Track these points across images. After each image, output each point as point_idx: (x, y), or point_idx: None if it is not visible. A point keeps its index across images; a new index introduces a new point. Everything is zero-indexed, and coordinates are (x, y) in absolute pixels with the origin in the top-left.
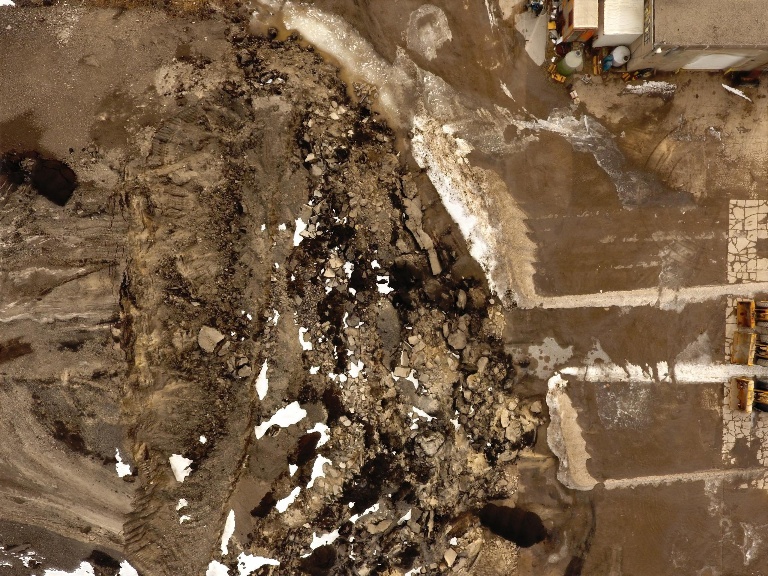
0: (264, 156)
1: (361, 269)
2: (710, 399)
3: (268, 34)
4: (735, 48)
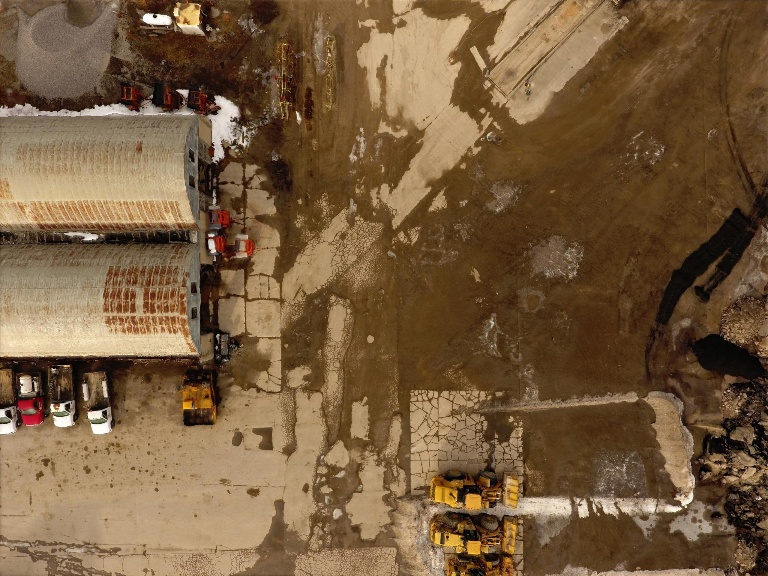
0: None
1: None
2: (536, 481)
3: None
4: None
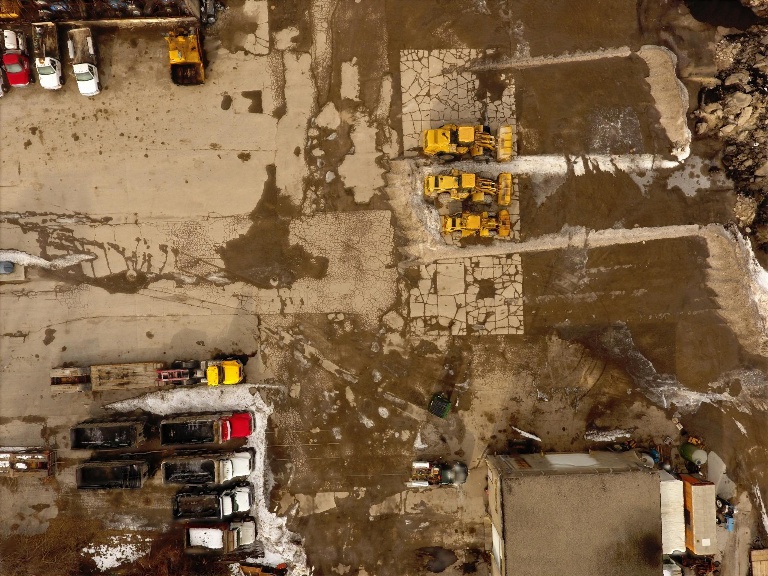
0: None
1: None
2: (530, 139)
3: None
4: (582, 471)
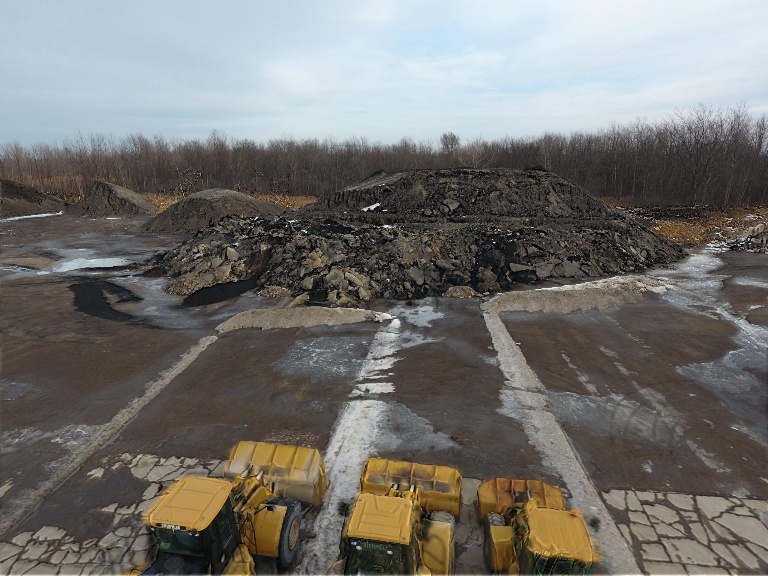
0: None
1: None
2: (288, 443)
3: None
4: None
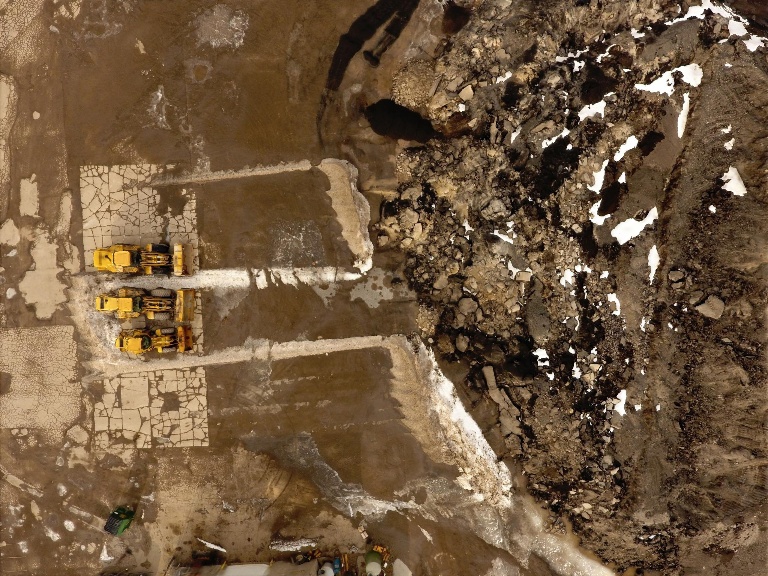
0: (659, 472)
1: (566, 372)
2: (212, 253)
3: (643, 572)
4: None
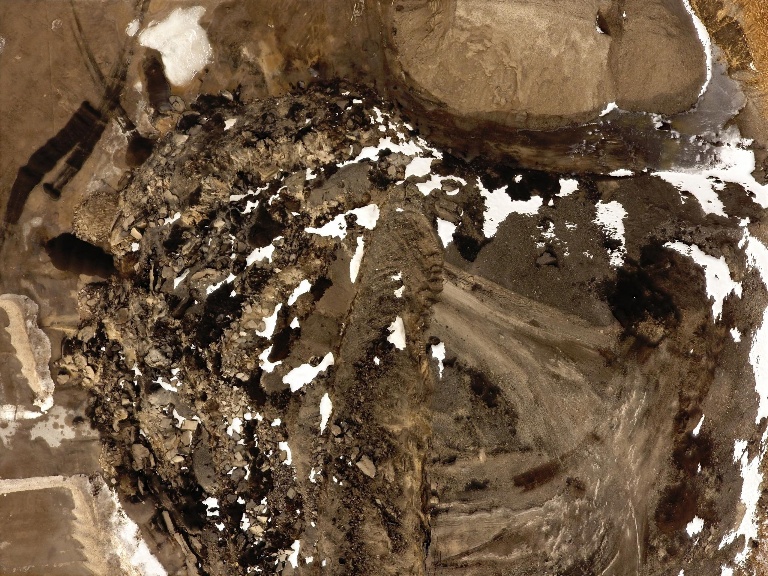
0: None
1: (232, 524)
2: None
3: None
4: None
